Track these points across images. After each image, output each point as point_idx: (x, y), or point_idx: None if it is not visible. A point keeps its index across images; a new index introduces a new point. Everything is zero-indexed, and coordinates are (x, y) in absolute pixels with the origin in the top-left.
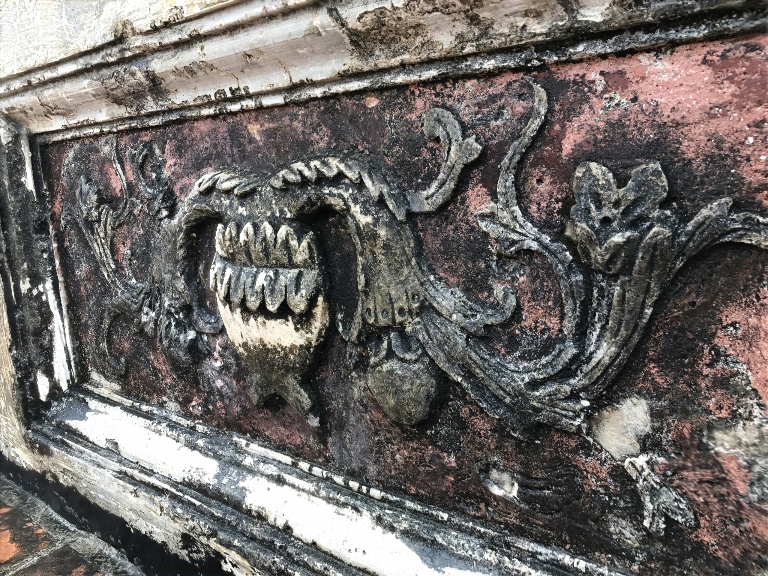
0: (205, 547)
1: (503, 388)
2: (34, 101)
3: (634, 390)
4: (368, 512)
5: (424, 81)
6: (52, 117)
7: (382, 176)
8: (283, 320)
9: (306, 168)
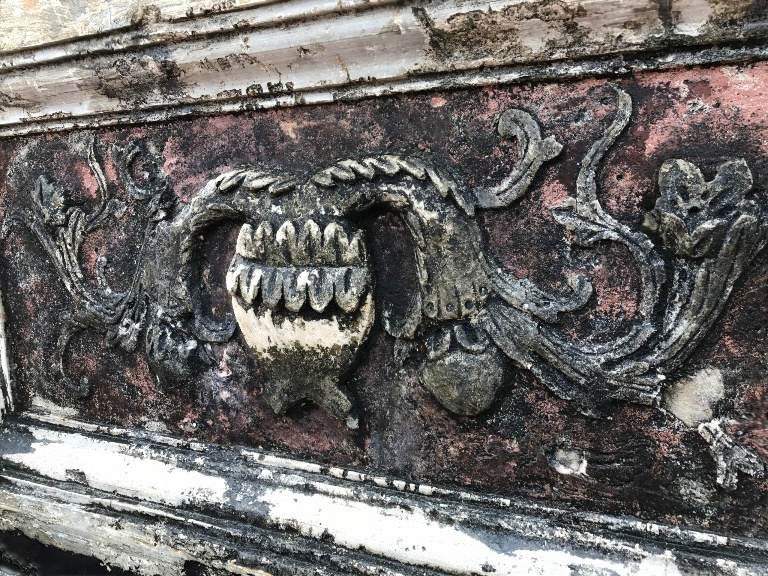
0: (219, 572)
1: (578, 370)
2: None
3: (709, 361)
4: (421, 509)
5: (502, 83)
6: (6, 109)
7: (448, 173)
8: (326, 320)
9: (360, 165)
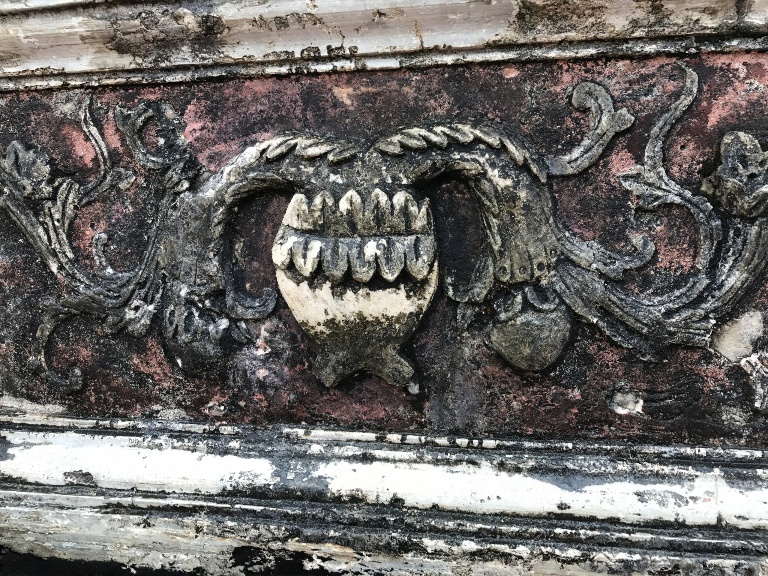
0: (276, 553)
1: (641, 321)
2: None
3: (752, 305)
4: (488, 462)
5: (579, 58)
6: None
7: (521, 142)
8: (393, 289)
9: (431, 134)
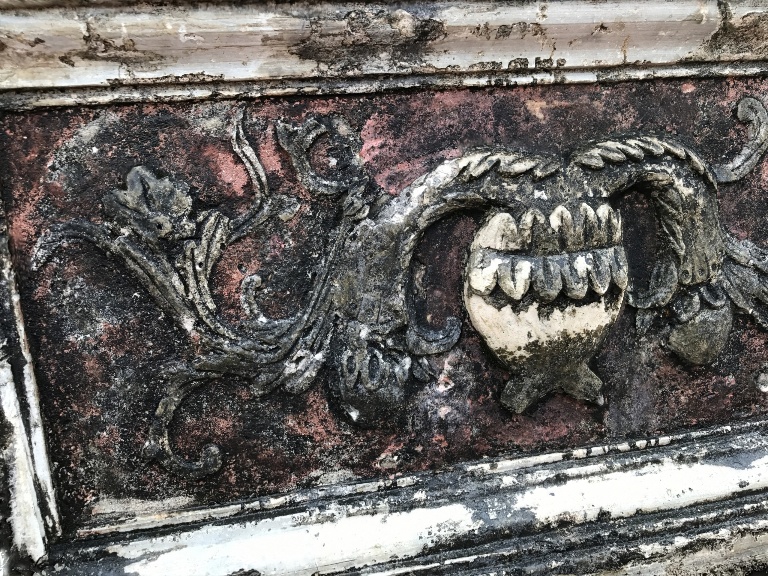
0: None
1: None
2: (66, 29)
3: None
4: (669, 458)
5: (745, 75)
6: (81, 62)
7: None
8: (596, 303)
9: (628, 146)
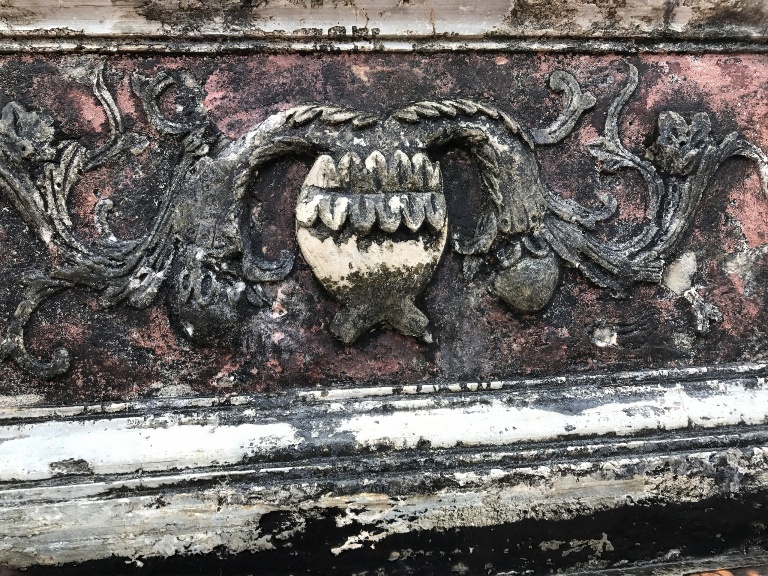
0: (308, 513)
1: (612, 263)
2: None
3: (688, 248)
4: (498, 400)
5: (554, 51)
6: None
7: (512, 116)
8: (413, 241)
9: (442, 105)
